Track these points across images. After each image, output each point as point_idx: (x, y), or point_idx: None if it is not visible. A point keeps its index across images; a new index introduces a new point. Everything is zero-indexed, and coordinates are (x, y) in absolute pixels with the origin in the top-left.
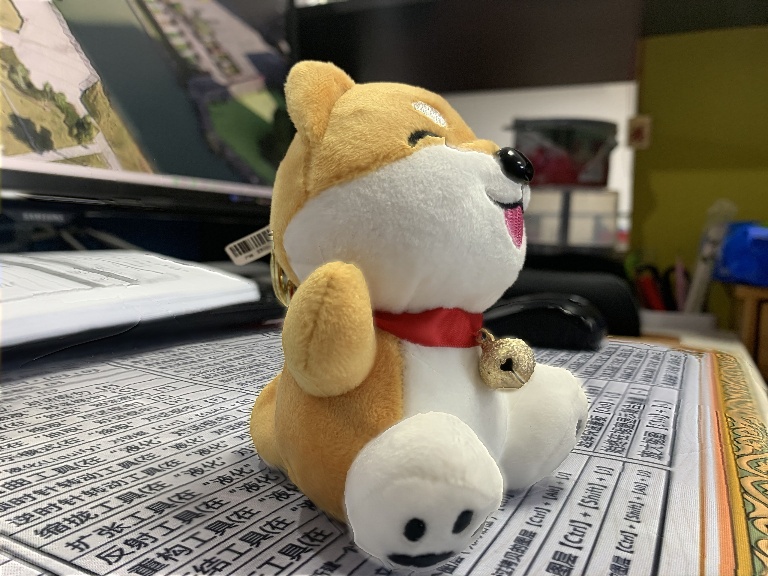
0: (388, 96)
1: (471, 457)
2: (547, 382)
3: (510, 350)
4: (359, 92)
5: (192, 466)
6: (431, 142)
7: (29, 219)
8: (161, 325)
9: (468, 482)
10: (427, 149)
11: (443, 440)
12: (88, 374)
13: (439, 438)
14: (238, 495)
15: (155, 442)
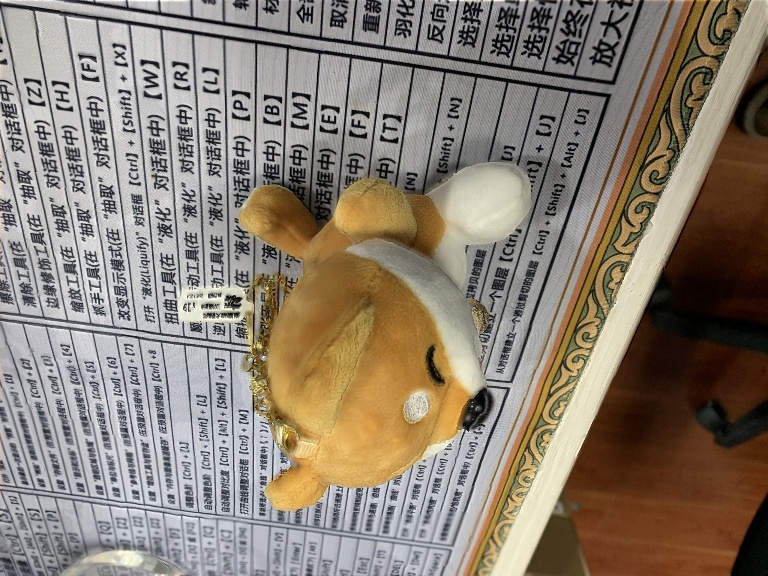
0: None
1: None
2: None
3: None
4: None
5: (232, 241)
6: None
7: None
8: None
9: None
10: None
11: None
12: None
13: None
14: (295, 269)
15: (166, 213)
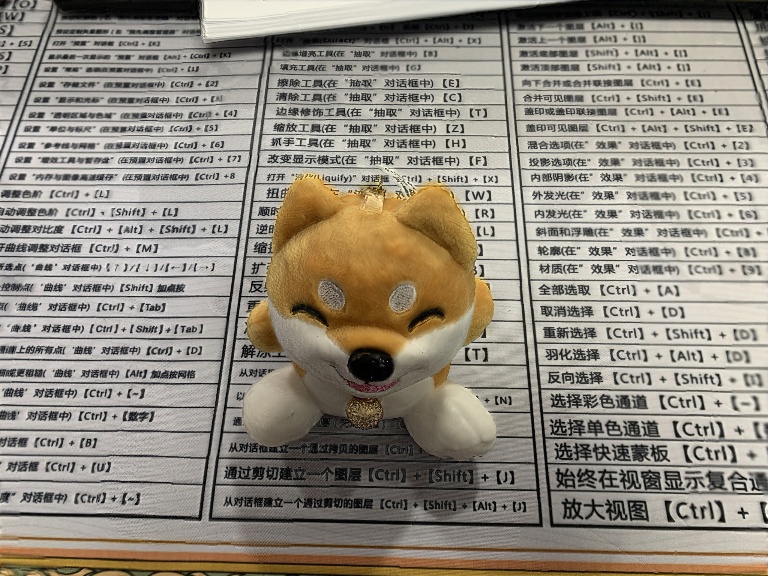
0: (308, 266)
1: (254, 431)
2: (440, 429)
3: (351, 414)
4: (319, 233)
5: None
6: (303, 321)
7: None
8: None
9: (250, 434)
10: (296, 324)
11: (250, 417)
12: (466, 47)
13: (250, 415)
14: None
15: None
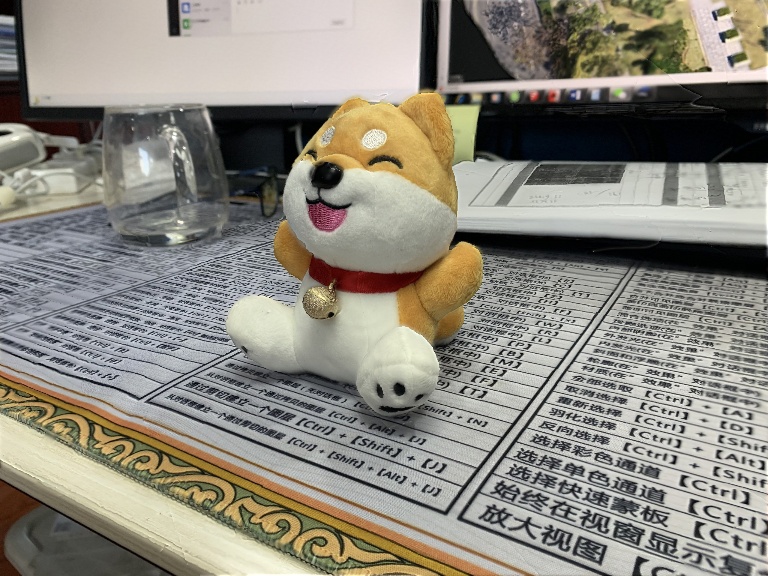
0: None
1: None
2: None
3: None
4: None
5: None
6: (303, 158)
7: (757, 130)
8: (698, 250)
9: None
10: None
11: None
12: (592, 270)
13: None
14: None
15: None
